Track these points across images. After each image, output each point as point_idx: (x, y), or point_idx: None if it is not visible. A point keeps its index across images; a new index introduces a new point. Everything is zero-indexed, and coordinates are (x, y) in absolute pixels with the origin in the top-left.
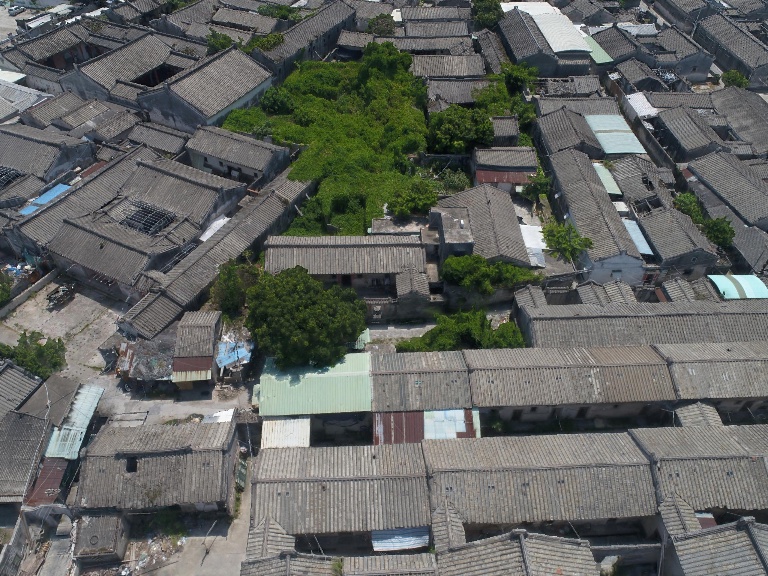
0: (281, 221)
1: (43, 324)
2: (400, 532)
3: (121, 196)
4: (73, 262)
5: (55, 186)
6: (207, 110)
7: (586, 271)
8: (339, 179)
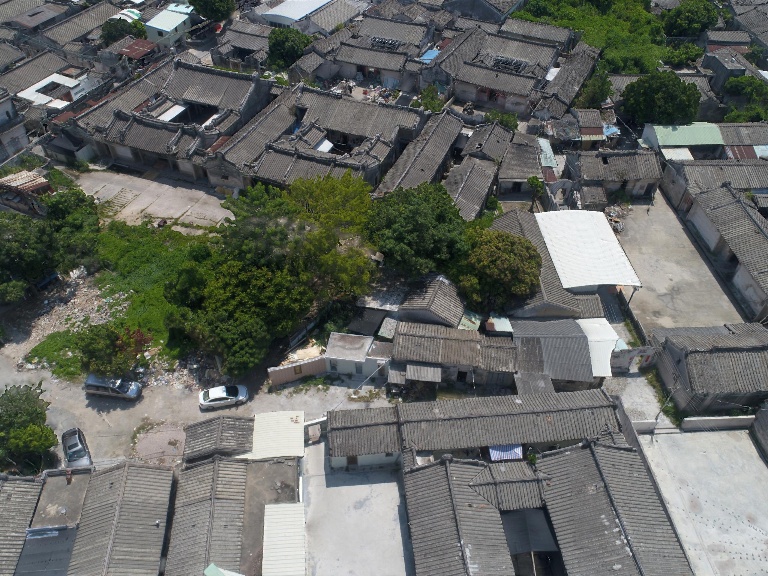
0: (590, 71)
1: None
2: (766, 192)
3: (482, 54)
4: (476, 87)
5: (427, 51)
6: (501, 10)
7: None
8: (619, 48)
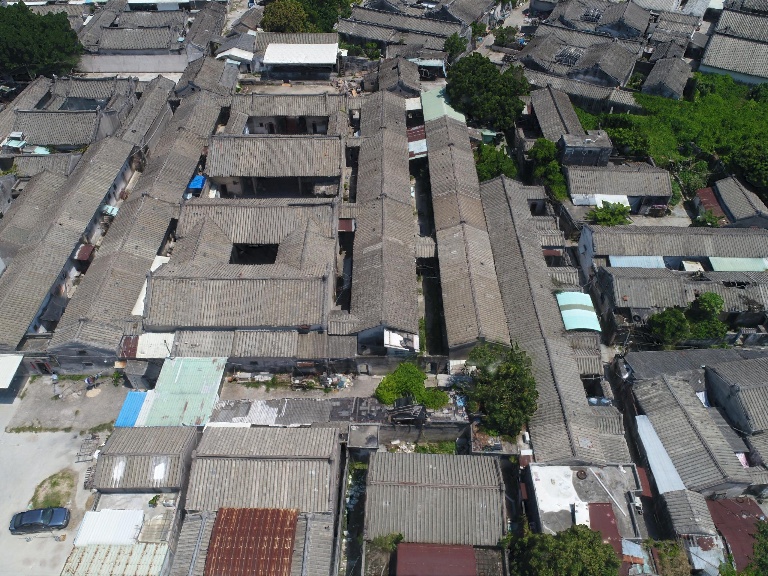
0: (594, 105)
1: (492, 60)
2: None
3: None
4: None
5: None
6: (710, 60)
7: (577, 226)
8: None
